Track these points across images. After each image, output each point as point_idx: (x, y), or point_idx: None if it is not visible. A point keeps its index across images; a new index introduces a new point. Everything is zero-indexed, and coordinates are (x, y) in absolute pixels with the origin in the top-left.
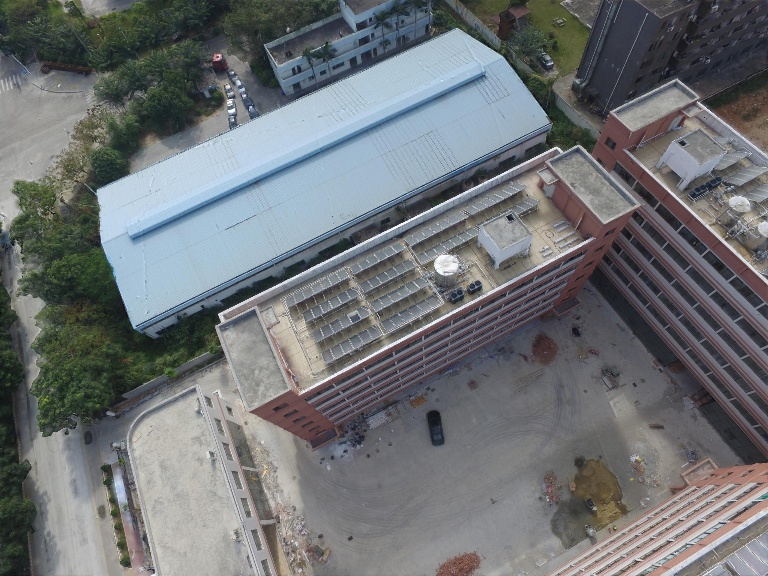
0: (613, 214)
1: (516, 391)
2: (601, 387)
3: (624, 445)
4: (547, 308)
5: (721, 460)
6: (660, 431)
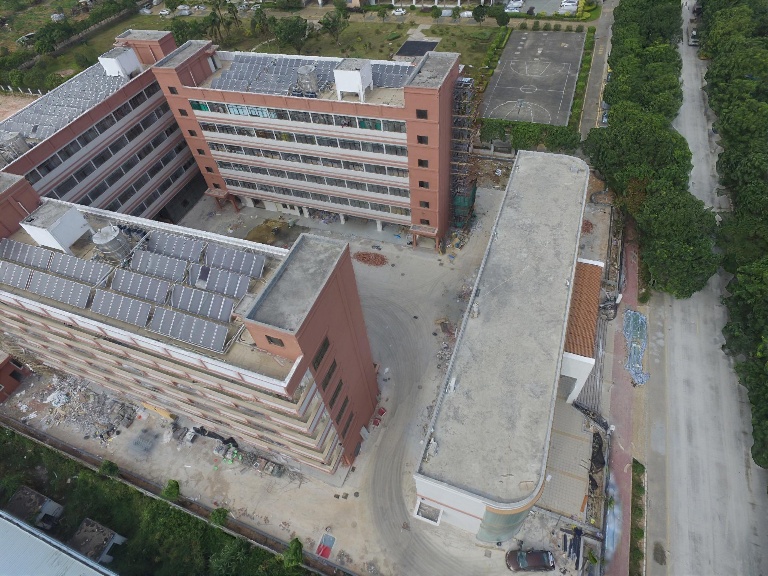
0: (11, 182)
1: None
2: None
3: None
4: None
5: (205, 206)
6: None
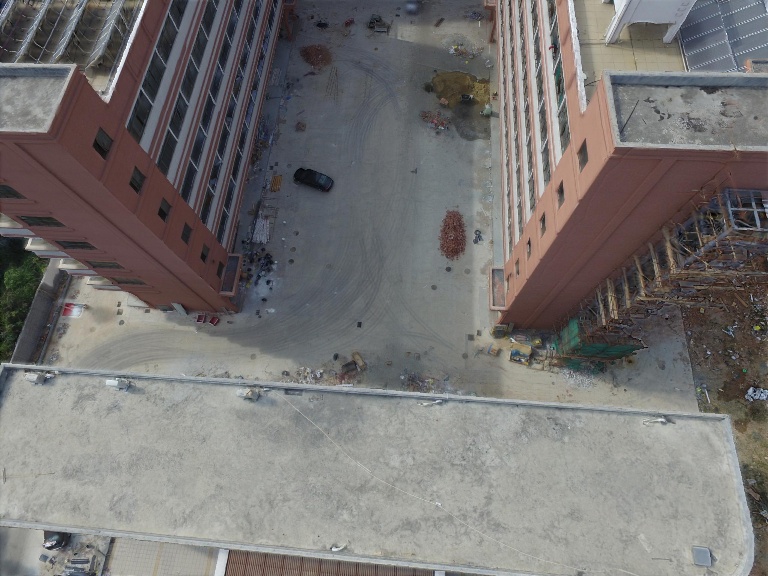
0: None
1: (335, 97)
2: (381, 37)
3: (438, 51)
4: (279, 2)
5: None
6: (444, 22)
